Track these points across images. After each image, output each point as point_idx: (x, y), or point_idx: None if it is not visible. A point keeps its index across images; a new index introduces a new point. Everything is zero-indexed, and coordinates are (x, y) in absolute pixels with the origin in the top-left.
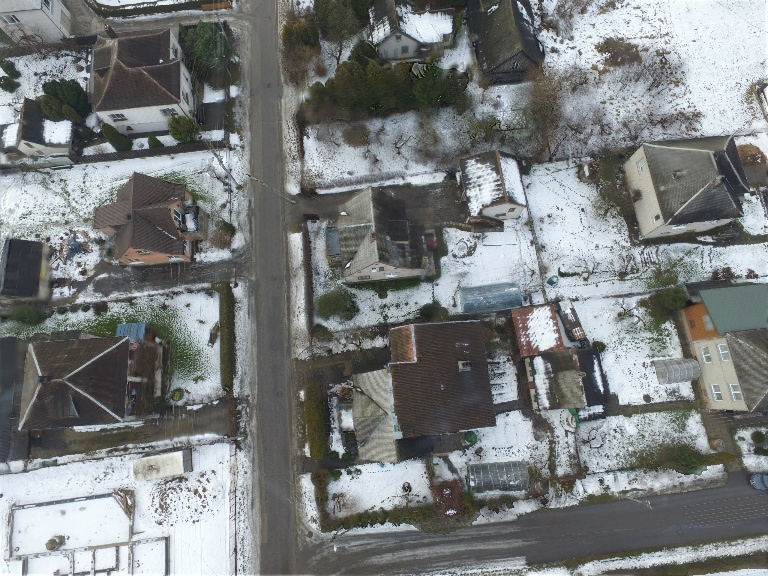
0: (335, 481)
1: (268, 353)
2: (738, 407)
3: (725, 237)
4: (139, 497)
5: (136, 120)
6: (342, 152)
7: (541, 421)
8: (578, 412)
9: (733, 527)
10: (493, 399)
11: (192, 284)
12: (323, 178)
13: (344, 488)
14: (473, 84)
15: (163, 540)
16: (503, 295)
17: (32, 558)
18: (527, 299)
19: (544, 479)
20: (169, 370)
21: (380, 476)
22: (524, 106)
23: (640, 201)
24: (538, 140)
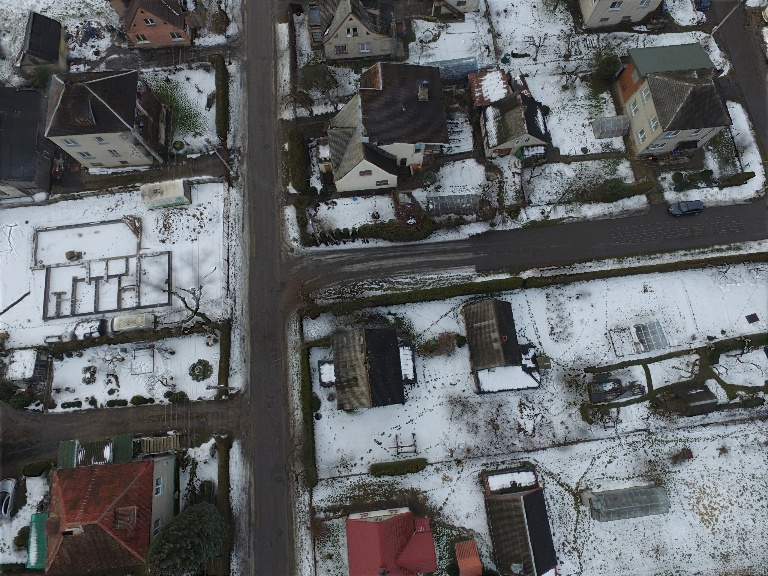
0: (314, 210)
1: (257, 115)
2: (656, 134)
3: (658, 27)
4: (145, 223)
5: None
6: None
7: (492, 167)
8: (523, 152)
9: (653, 244)
10: (451, 150)
11: (192, 63)
12: None
13: (322, 216)
14: None
15: (166, 254)
16: (461, 65)
17: (54, 267)
18: None
19: (493, 208)
20: (171, 128)
21: (353, 207)
22: None
23: None
24: None
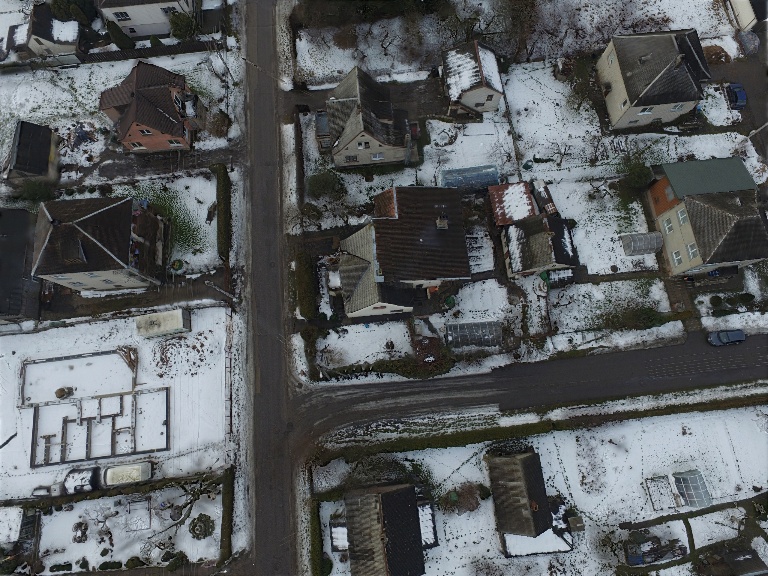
0: (323, 339)
1: (262, 229)
2: (695, 263)
3: (690, 127)
4: (142, 354)
5: (139, 20)
6: (332, 54)
7: (515, 288)
8: (549, 276)
9: (691, 379)
10: (471, 269)
11: (191, 169)
12: (314, 76)
13: (332, 346)
14: None
15: (164, 390)
16: (481, 175)
17: (43, 406)
18: (504, 181)
19: (517, 337)
20: (169, 244)
21: (365, 335)
22: (504, 13)
23: (610, 93)
24: (517, 43)
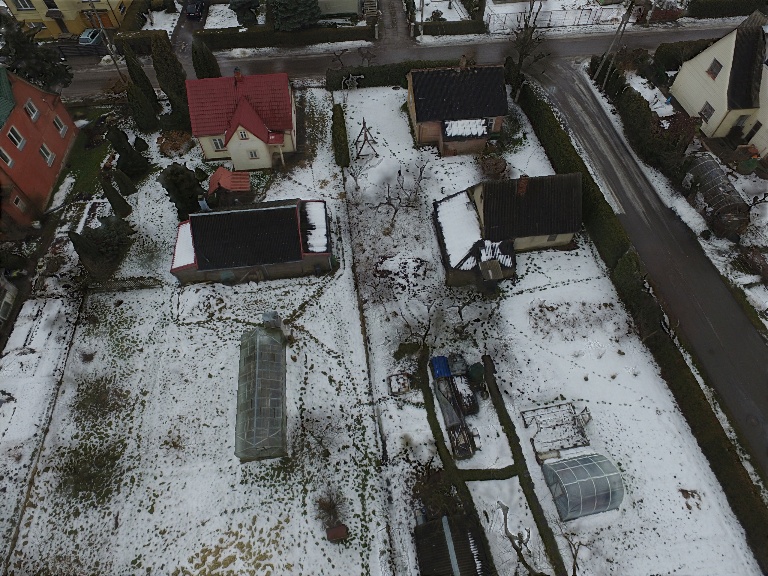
0: (635, 74)
1: None
2: None
3: None
4: None
5: None
6: None
7: None
8: None
9: None
10: None
11: None
12: None
13: (631, 80)
14: None
15: None
16: None
17: None
18: None
19: None
20: None
21: None
22: None
23: None
24: None
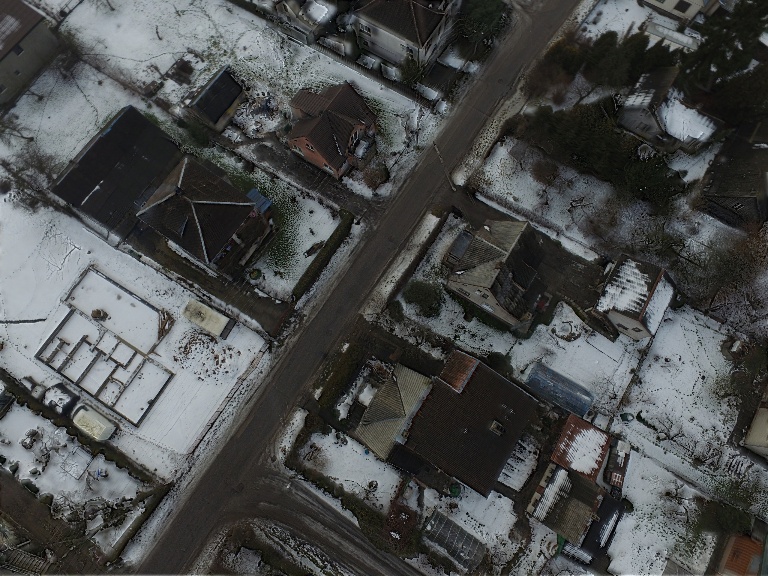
0: (322, 434)
1: (344, 294)
2: None
3: None
4: (176, 328)
5: (377, 40)
6: (521, 176)
7: (525, 526)
8: (565, 545)
9: None
10: None
11: (326, 198)
12: (489, 187)
13: (325, 445)
14: (682, 196)
15: (169, 373)
16: (573, 395)
17: (78, 313)
18: (591, 415)
19: (492, 575)
20: (263, 251)
21: (359, 459)
22: (716, 248)
23: (767, 411)
24: (707, 287)
